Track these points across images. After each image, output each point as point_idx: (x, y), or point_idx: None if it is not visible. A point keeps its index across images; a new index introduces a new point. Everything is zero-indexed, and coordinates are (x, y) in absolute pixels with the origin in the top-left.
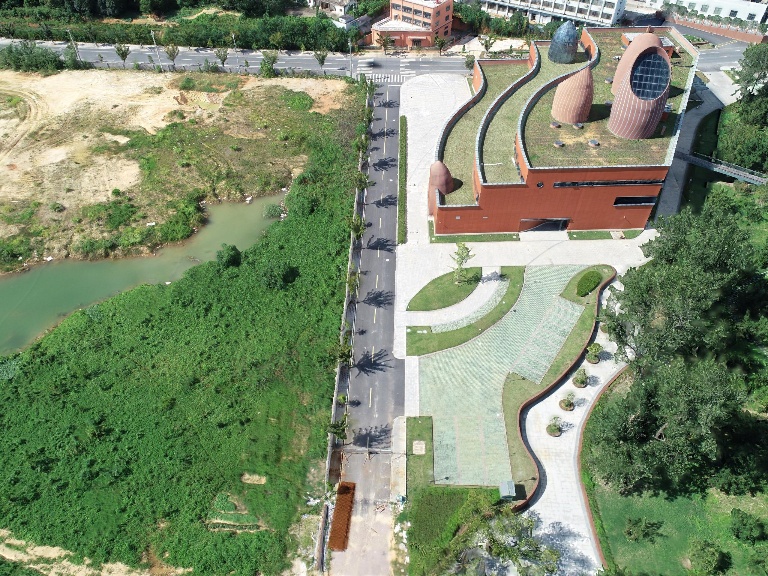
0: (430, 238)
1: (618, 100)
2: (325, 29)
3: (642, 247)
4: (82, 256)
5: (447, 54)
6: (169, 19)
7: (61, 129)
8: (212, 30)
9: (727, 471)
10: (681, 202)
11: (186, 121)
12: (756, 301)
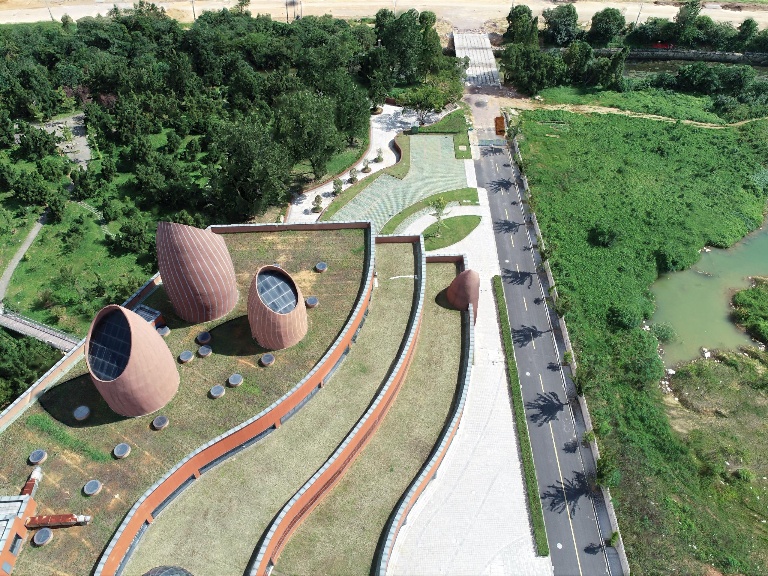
0: None
1: None
2: None
3: None
4: None
5: None
6: None
7: None
8: None
9: None
10: None
11: None
12: None
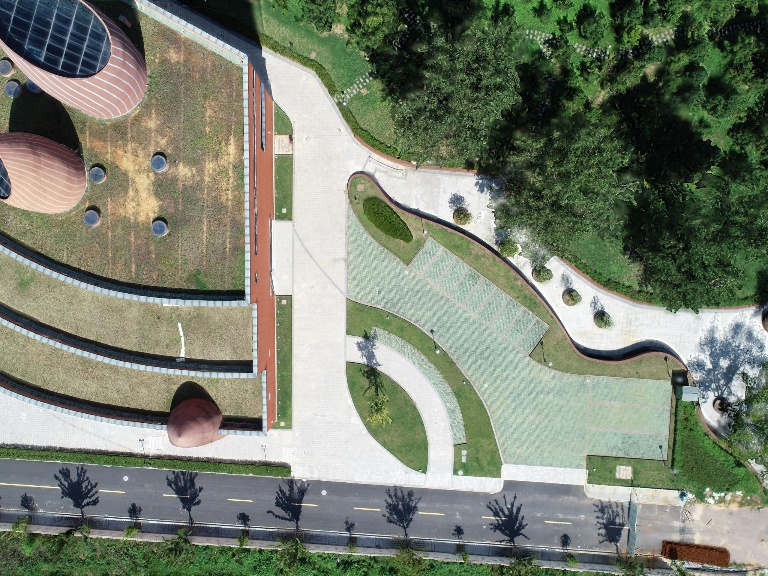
0: (280, 429)
1: (80, 101)
2: None
3: None
4: None
5: None
6: None
7: None
8: None
9: None
10: (209, 16)
11: None
12: None
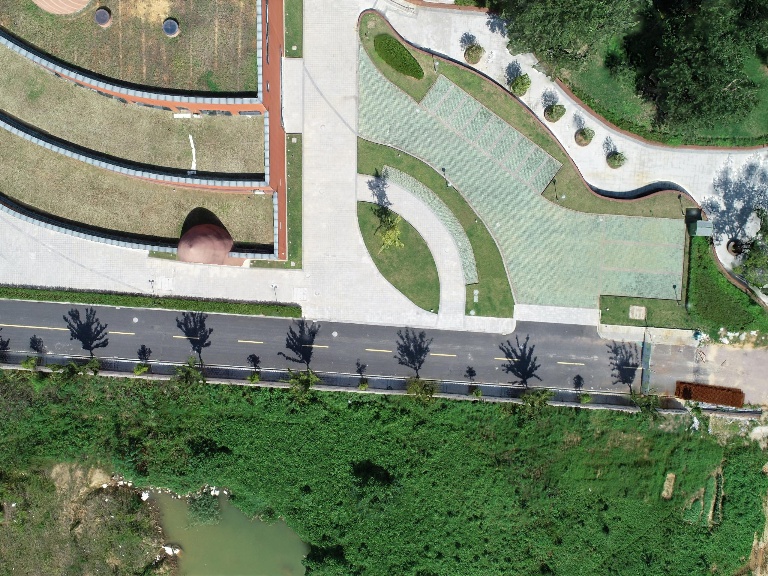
0: (291, 269)
1: None
2: None
3: None
4: None
5: None
6: None
7: None
8: None
9: None
10: None
11: None
12: None
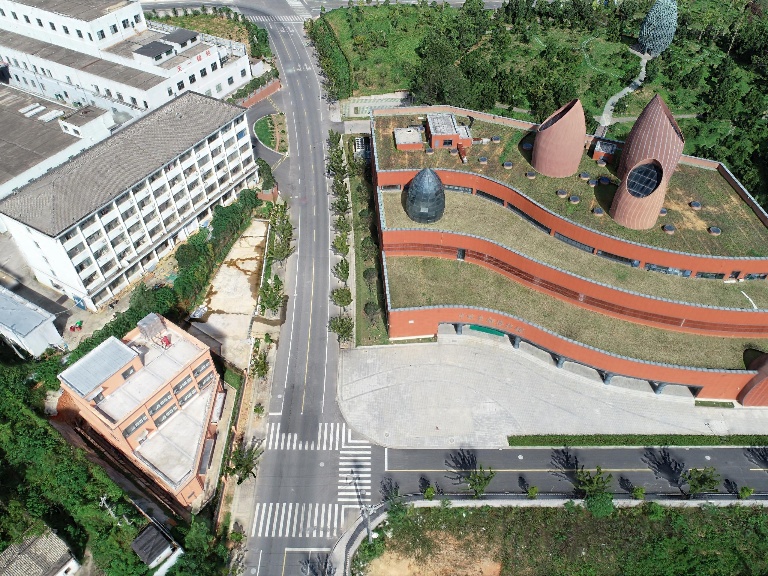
0: None
1: (668, 161)
2: None
3: None
4: None
5: None
6: None
7: None
8: None
9: None
10: None
11: None
12: None
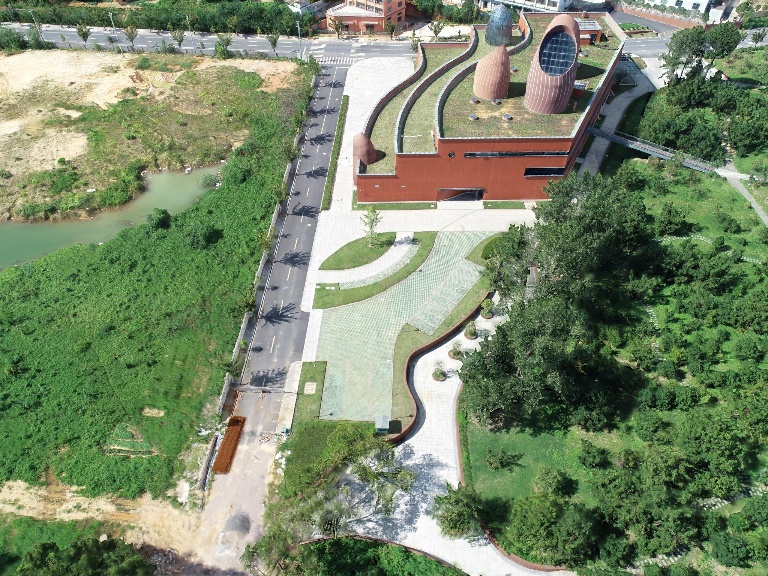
0: (352, 206)
1: (530, 76)
2: (281, 13)
3: (534, 210)
4: (23, 218)
5: (398, 39)
6: (133, 3)
7: (18, 104)
8: (172, 13)
9: (582, 408)
10: None
11: (138, 98)
12: (643, 263)
